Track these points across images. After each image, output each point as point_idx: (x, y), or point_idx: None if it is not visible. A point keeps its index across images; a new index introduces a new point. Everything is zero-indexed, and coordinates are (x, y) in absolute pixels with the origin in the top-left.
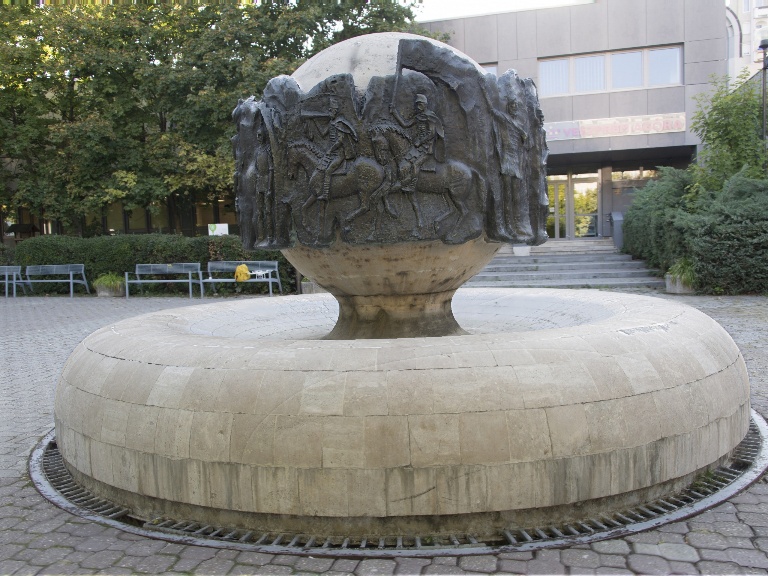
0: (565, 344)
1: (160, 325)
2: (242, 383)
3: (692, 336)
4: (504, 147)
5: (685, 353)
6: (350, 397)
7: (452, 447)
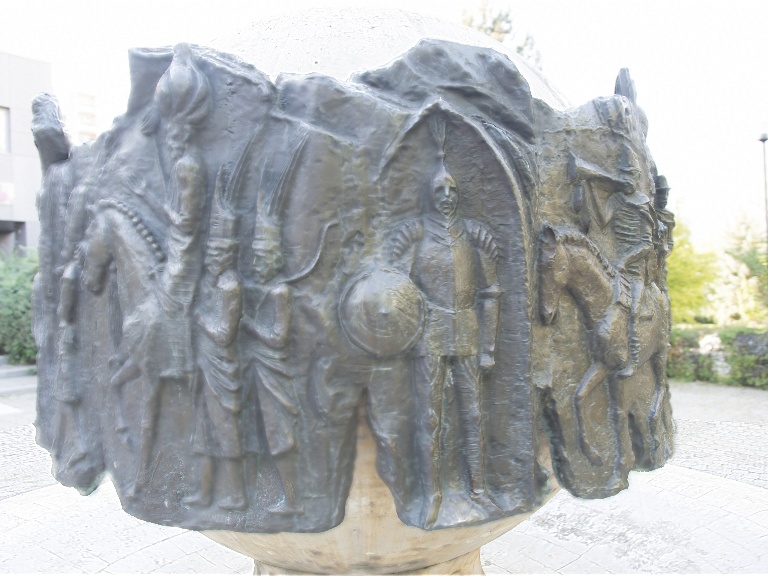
0: None
1: None
2: None
3: None
4: None
5: None
6: None
7: None
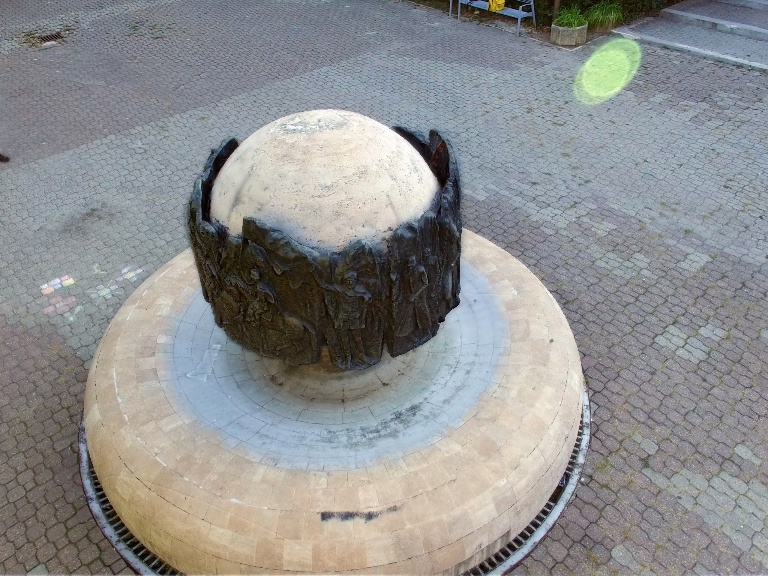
0: (260, 518)
1: (169, 300)
2: (105, 449)
3: (390, 530)
4: (339, 309)
5: (358, 548)
6: (132, 496)
7: (168, 548)
